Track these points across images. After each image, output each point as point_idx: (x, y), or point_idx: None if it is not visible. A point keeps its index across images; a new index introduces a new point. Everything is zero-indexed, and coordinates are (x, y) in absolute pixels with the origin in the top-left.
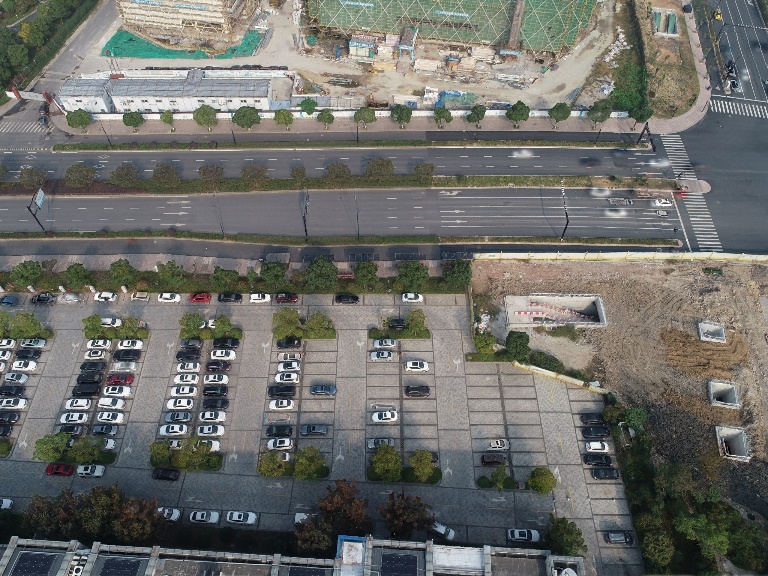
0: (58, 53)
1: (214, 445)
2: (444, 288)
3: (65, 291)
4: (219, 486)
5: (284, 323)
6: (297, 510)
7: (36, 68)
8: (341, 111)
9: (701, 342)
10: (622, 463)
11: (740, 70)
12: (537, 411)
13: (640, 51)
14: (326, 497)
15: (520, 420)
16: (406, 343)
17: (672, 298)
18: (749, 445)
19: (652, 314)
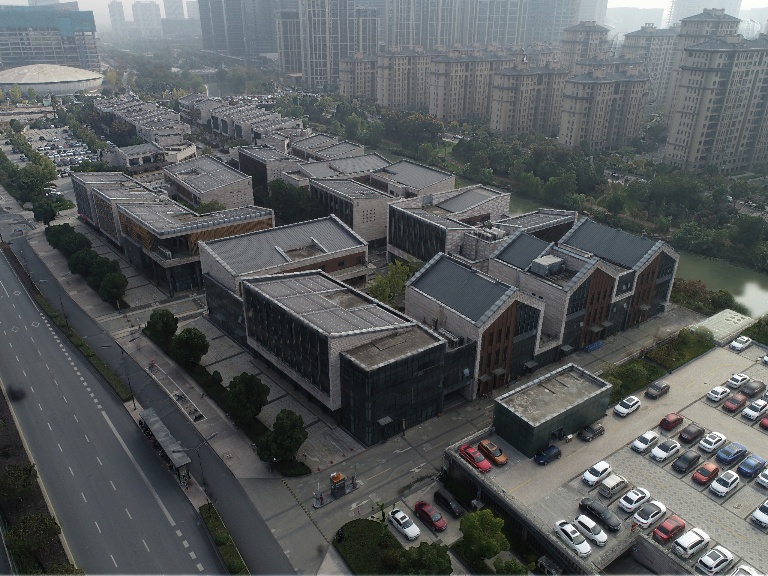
0: None
1: None
2: None
3: None
4: None
5: None
6: None
7: None
8: None
9: None
10: None
11: None
12: None
13: None
14: (94, 122)
15: None
16: None
17: None
18: None
19: None
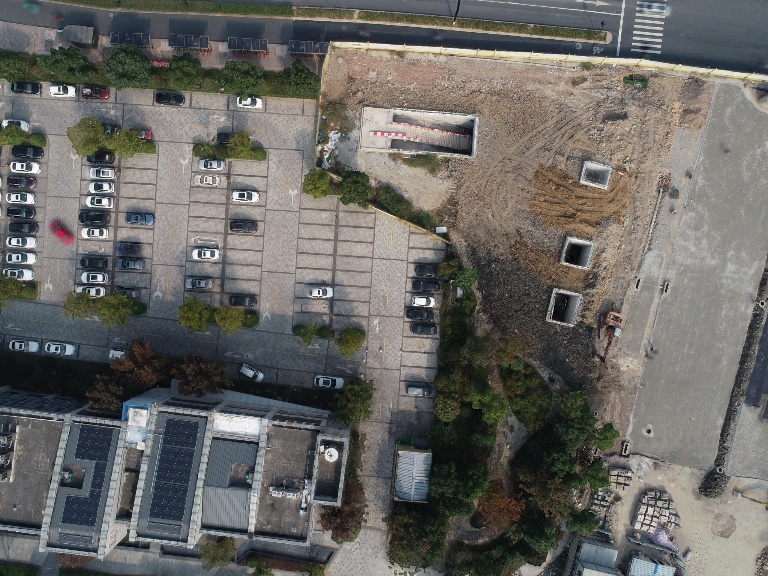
0: None
1: (25, 275)
2: (288, 92)
3: None
4: (37, 315)
5: (79, 144)
6: (115, 344)
7: None
8: None
9: (577, 187)
10: (443, 320)
11: None
12: (371, 257)
13: None
14: None
15: (350, 266)
16: (237, 164)
17: (568, 122)
18: (581, 309)
19: (535, 144)
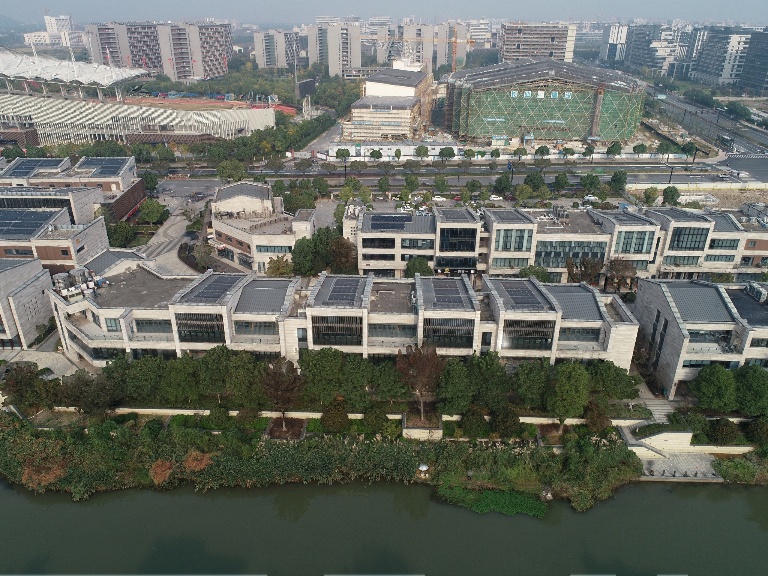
0: (306, 147)
1: None
2: (609, 194)
3: (372, 198)
4: None
5: (527, 187)
6: None
7: (297, 150)
8: (502, 155)
9: None
10: None
11: (738, 148)
12: None
13: (672, 143)
14: None
15: None
16: None
17: None
18: None
19: None
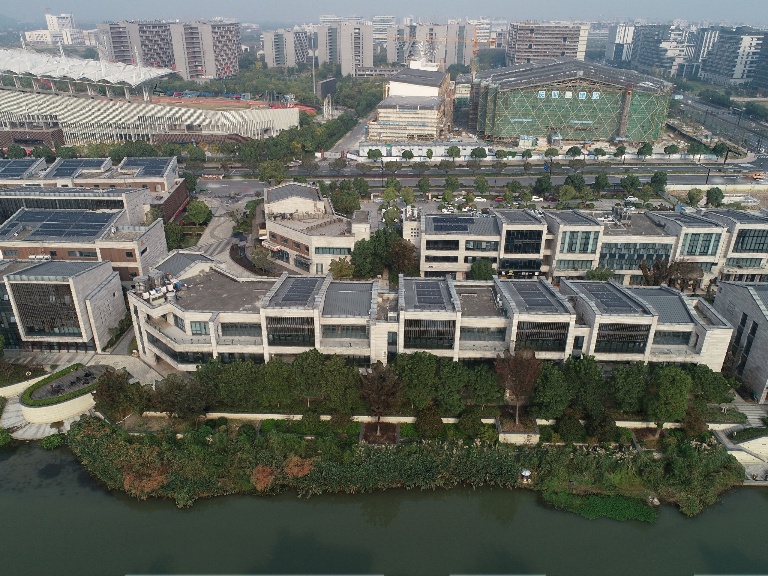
0: (333, 147)
1: None
2: (649, 195)
3: None
4: None
5: (570, 188)
6: None
7: (325, 150)
8: (533, 155)
9: None
10: None
11: (765, 149)
12: None
13: (699, 144)
14: None
15: None
16: None
17: None
18: None
19: None
